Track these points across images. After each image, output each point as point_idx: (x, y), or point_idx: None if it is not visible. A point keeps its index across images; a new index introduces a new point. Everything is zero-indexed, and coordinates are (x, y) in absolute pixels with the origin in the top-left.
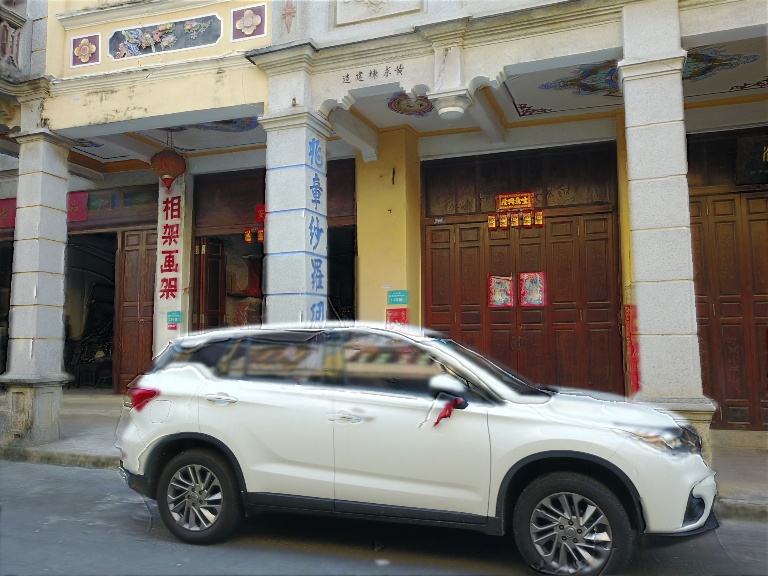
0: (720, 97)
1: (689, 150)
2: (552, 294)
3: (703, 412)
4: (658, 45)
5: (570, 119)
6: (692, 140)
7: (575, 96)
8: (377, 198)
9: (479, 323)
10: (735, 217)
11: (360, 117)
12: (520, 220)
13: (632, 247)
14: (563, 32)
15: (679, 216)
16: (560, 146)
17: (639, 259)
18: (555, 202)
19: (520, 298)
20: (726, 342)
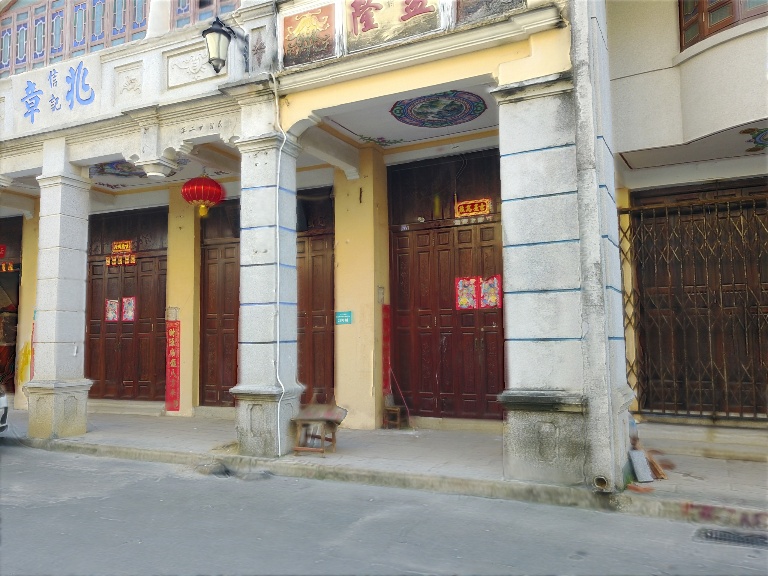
0: (215, 178)
1: (213, 212)
2: (139, 312)
3: (50, 388)
4: (55, 167)
5: (145, 190)
6: (214, 205)
7: (122, 178)
8: (32, 245)
9: (99, 333)
10: (234, 260)
11: (5, 191)
12: (123, 260)
13: (37, 290)
14: (24, 155)
15: (55, 272)
16: (145, 208)
17: (39, 297)
18: (144, 247)
19: (122, 315)
20: (225, 346)
